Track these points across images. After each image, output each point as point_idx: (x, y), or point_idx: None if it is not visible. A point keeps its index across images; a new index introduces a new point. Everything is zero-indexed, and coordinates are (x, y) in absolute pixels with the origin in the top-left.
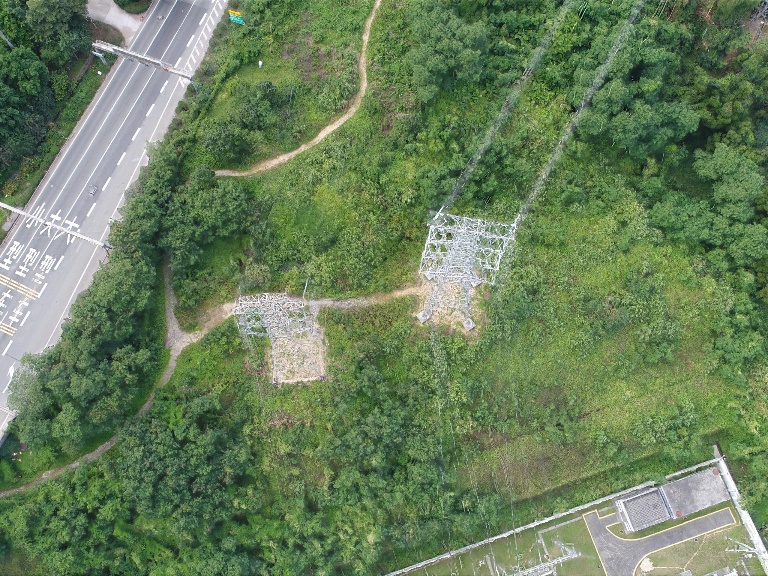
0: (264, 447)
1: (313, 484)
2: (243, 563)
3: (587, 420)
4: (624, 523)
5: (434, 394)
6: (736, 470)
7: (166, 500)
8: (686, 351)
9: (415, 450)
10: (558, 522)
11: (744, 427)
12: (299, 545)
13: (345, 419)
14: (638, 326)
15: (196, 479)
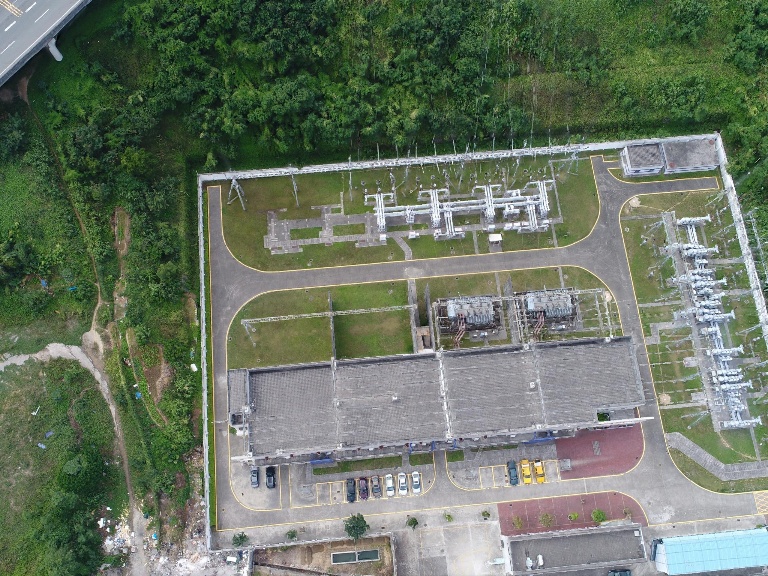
0: (344, 18)
1: (377, 59)
2: (310, 95)
3: (612, 71)
4: (624, 169)
5: (491, 8)
6: (730, 151)
7: (262, 24)
8: (709, 39)
9: (466, 43)
10: (568, 157)
11: (745, 112)
12: (355, 102)
13: (414, 10)
14: (673, 0)
15: (289, 12)
